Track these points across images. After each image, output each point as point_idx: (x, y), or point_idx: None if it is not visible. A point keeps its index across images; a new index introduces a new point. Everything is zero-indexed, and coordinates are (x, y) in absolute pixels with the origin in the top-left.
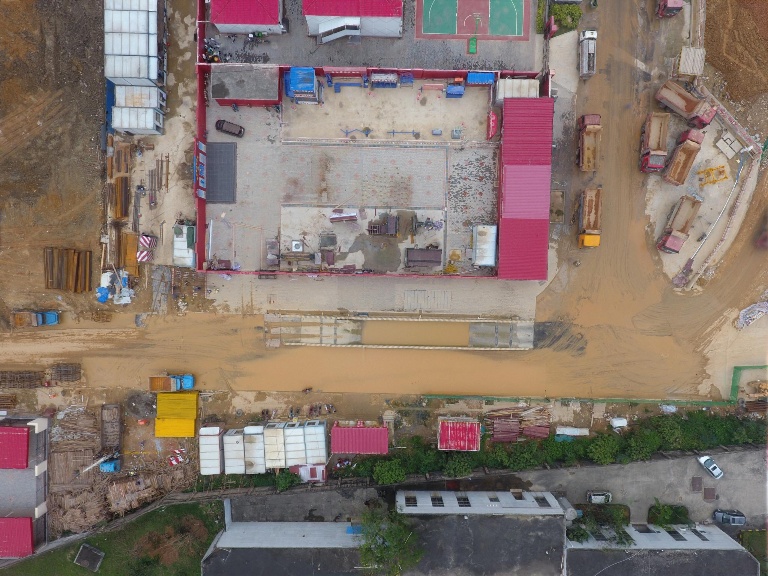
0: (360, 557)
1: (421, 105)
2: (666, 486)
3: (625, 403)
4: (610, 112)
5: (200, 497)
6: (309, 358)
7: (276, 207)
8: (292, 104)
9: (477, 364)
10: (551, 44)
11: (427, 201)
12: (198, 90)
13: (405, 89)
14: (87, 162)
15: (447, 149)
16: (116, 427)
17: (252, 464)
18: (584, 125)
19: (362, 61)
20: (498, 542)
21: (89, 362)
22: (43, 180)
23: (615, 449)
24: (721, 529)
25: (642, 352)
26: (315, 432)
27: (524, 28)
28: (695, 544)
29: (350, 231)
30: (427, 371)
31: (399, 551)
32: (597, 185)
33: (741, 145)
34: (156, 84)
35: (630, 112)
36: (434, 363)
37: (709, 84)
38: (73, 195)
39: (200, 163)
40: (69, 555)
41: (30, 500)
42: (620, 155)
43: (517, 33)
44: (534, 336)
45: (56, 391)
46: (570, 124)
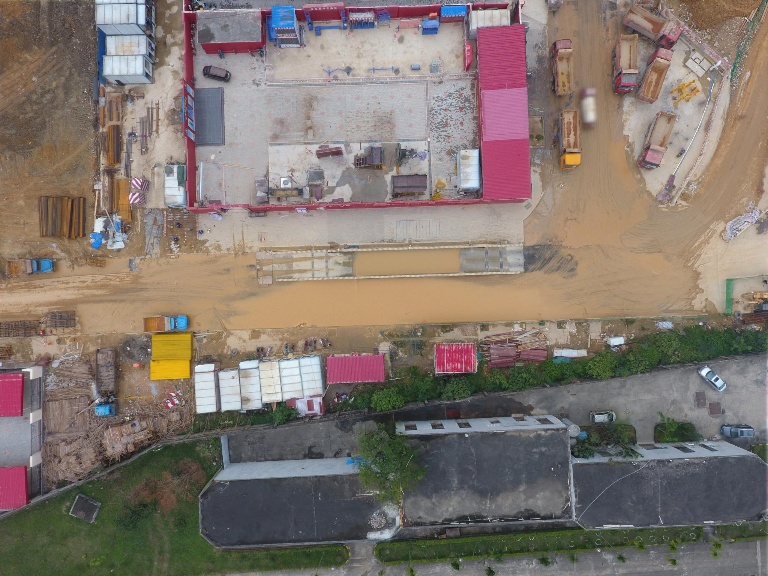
0: (361, 483)
1: (399, 43)
2: (670, 403)
3: (621, 322)
4: (581, 40)
5: (197, 435)
6: (302, 293)
7: (264, 147)
8: (275, 49)
9: (469, 291)
10: None
11: (410, 133)
12: (185, 37)
13: (383, 29)
14: (80, 113)
15: (426, 83)
16: (111, 371)
17: (248, 399)
18: (556, 50)
19: None
20: (501, 460)
21: (84, 309)
22: (38, 132)
23: (614, 363)
24: None
25: (633, 270)
26: (310, 363)
27: None
28: (704, 454)
29: (337, 166)
30: (420, 300)
31: (401, 474)
32: None
33: (710, 63)
34: (145, 32)
35: (600, 39)
36: (426, 291)
37: None
38: (67, 145)
39: (188, 105)
40: (65, 507)
41: (25, 452)
42: (594, 80)
43: None
44: (524, 260)
45: (51, 340)
46: (543, 53)
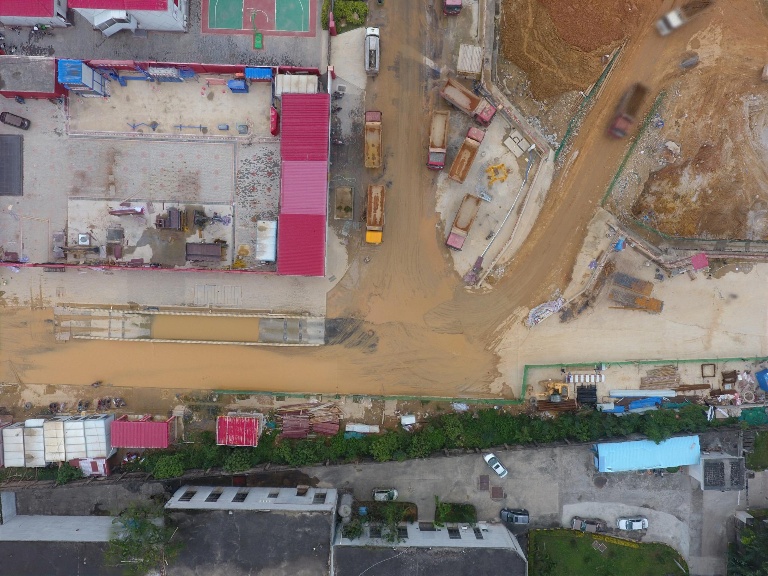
0: None
1: (208, 100)
2: (453, 484)
3: (417, 401)
4: (399, 109)
5: None
6: (99, 352)
7: (63, 200)
8: (78, 97)
9: (268, 360)
10: (338, 40)
11: (215, 196)
12: None
13: (192, 83)
14: None
15: (235, 144)
16: None
17: (32, 457)
18: (365, 121)
19: (148, 55)
20: (265, 538)
21: None
22: None
23: (394, 446)
24: (509, 528)
25: (434, 350)
26: (95, 426)
27: (310, 24)
28: (466, 542)
29: (138, 225)
30: (218, 366)
31: (164, 546)
32: (387, 182)
33: (529, 144)
34: None
35: (419, 109)
36: (224, 358)
37: (513, 83)
38: None
39: None
40: None
41: None
42: (410, 152)
43: (303, 29)
44: (325, 332)
45: None
46: (359, 121)
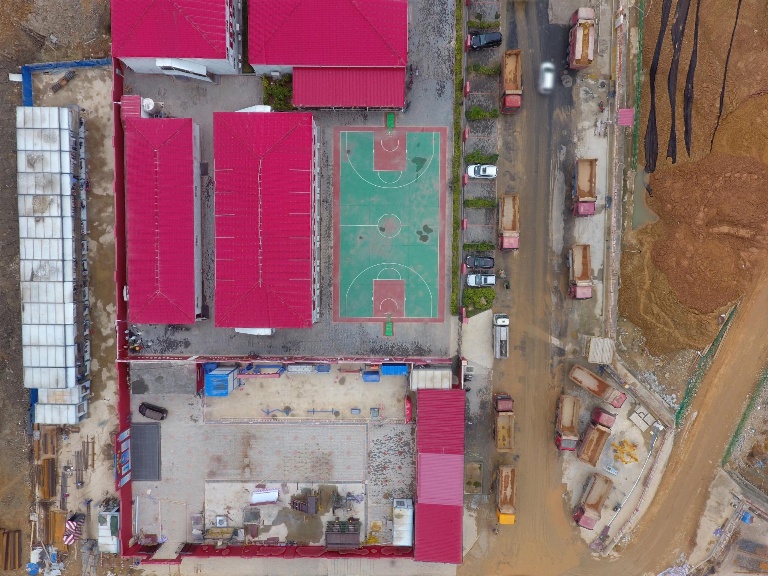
0: None
1: (340, 384)
2: None
3: None
4: (526, 386)
5: None
6: None
7: (200, 483)
8: None
9: None
10: (466, 325)
11: (348, 475)
12: (119, 385)
13: None
14: (15, 445)
15: (366, 425)
16: None
17: None
18: (497, 409)
19: (281, 344)
20: None
21: None
22: None
23: None
24: None
25: None
26: None
27: (439, 310)
28: None
29: None
30: None
31: None
32: (514, 456)
33: (654, 418)
34: (77, 384)
35: (545, 386)
36: None
37: (628, 339)
38: (2, 476)
39: (123, 453)
40: None
41: None
42: (536, 427)
43: (432, 315)
44: None
45: None
46: (487, 398)
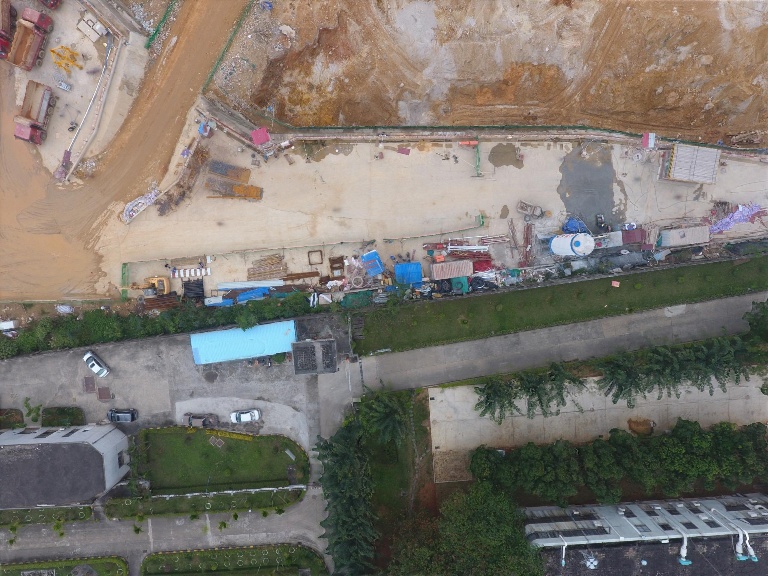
0: None
1: None
2: (58, 388)
3: (19, 305)
4: None
5: None
6: None
7: None
8: None
9: None
10: None
11: None
12: None
13: None
14: None
15: None
16: None
17: None
18: None
19: None
20: None
21: None
22: None
23: None
24: (121, 429)
25: (31, 251)
26: None
27: None
28: (44, 440)
29: None
30: None
31: None
32: None
33: (104, 27)
34: None
35: None
36: None
37: None
38: None
39: None
40: None
41: None
42: None
43: None
44: None
45: None
46: None
